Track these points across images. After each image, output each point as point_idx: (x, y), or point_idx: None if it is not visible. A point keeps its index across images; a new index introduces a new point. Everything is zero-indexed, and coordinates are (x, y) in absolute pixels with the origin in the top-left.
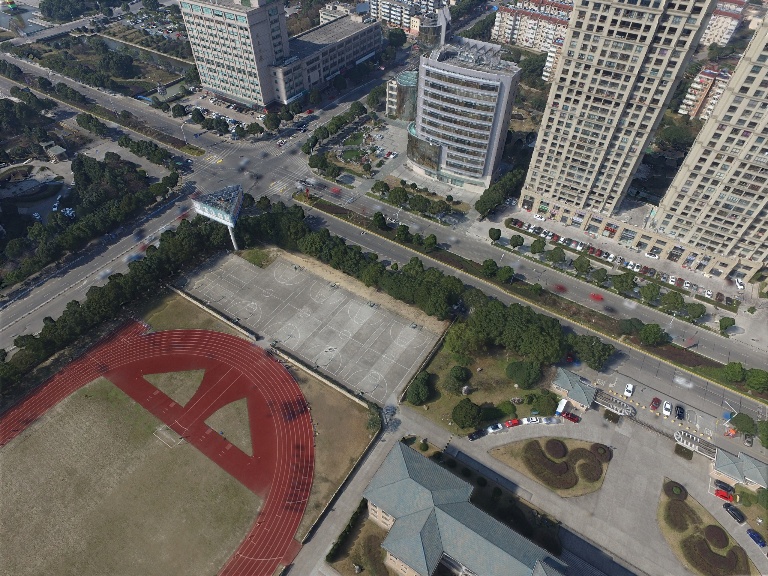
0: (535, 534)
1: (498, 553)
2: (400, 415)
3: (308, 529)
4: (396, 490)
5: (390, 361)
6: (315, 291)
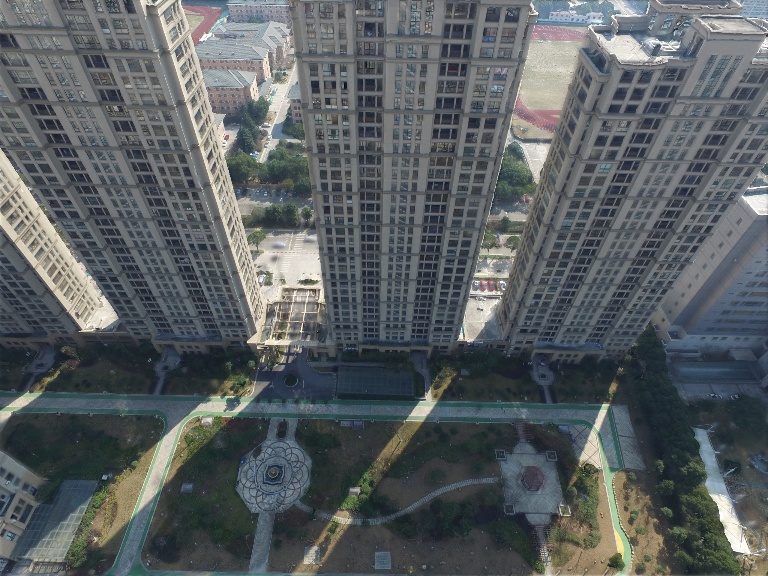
0: None
1: None
2: None
3: None
4: None
5: (543, 159)
6: None
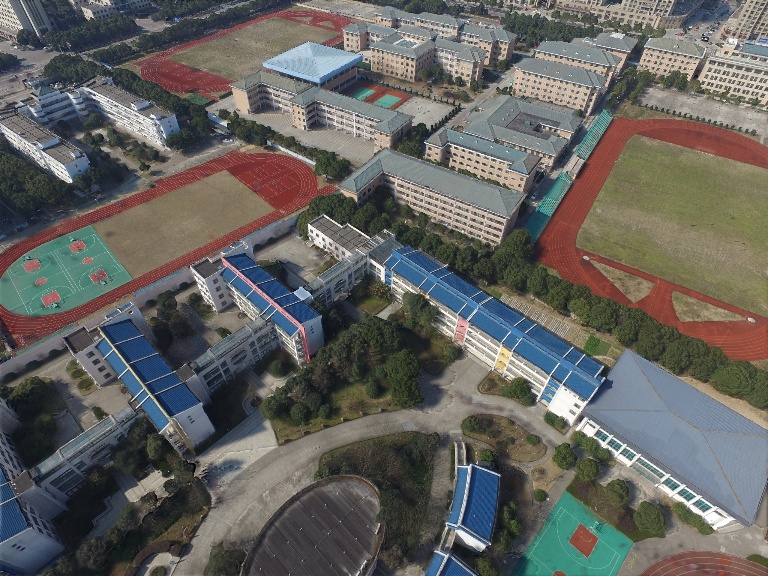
0: None
1: (411, 14)
2: None
3: None
4: (383, 9)
5: None
6: (352, 5)
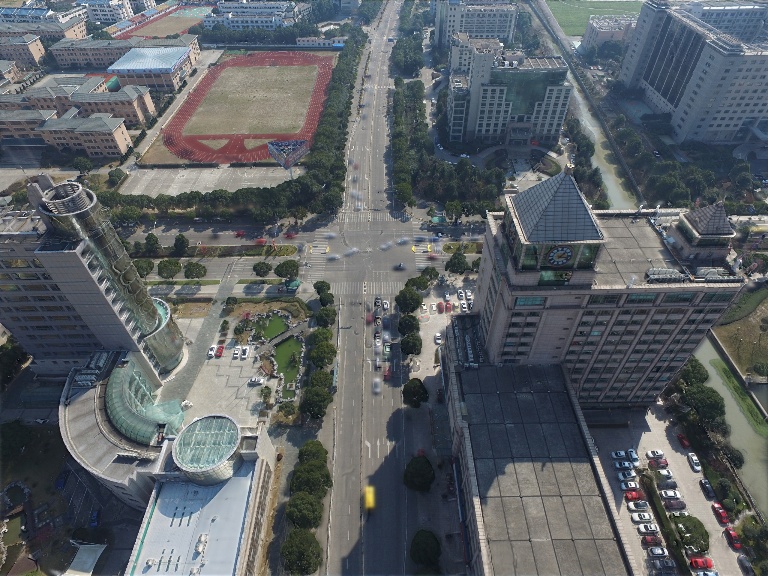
0: (52, 159)
1: None
2: (127, 170)
3: (159, 136)
4: None
5: (141, 184)
6: None
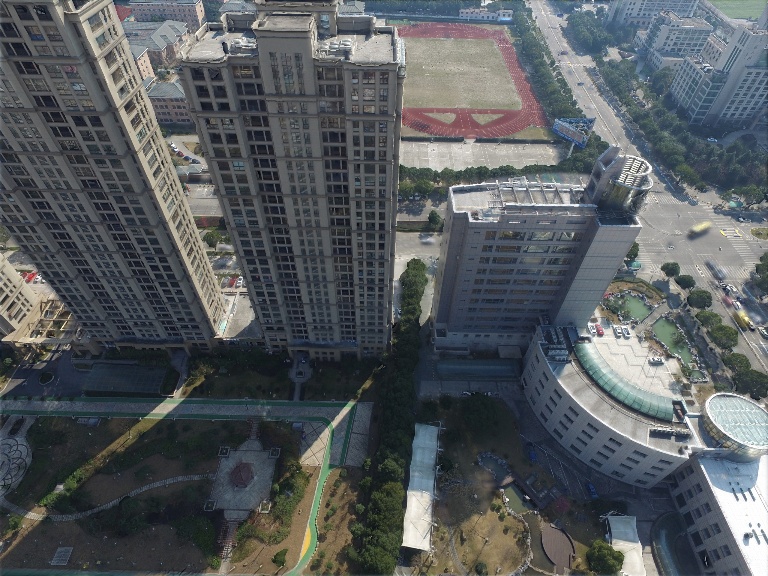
0: None
1: None
2: None
3: None
4: None
5: None
6: None
